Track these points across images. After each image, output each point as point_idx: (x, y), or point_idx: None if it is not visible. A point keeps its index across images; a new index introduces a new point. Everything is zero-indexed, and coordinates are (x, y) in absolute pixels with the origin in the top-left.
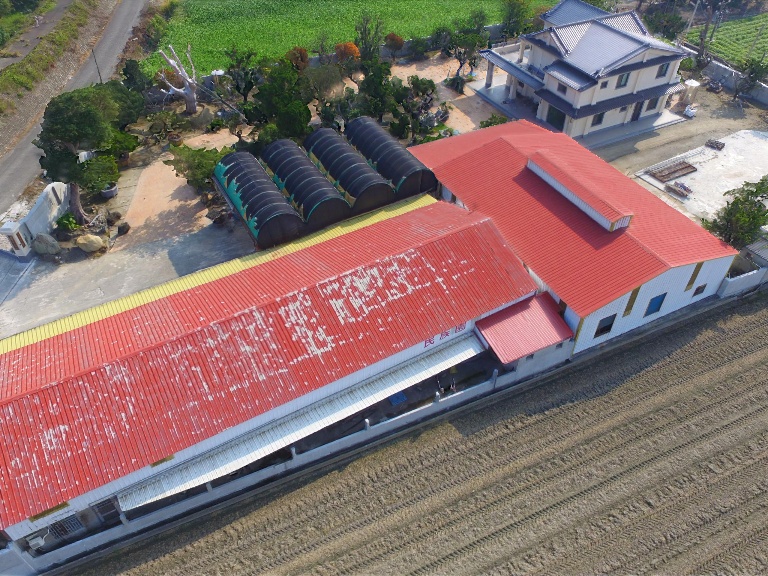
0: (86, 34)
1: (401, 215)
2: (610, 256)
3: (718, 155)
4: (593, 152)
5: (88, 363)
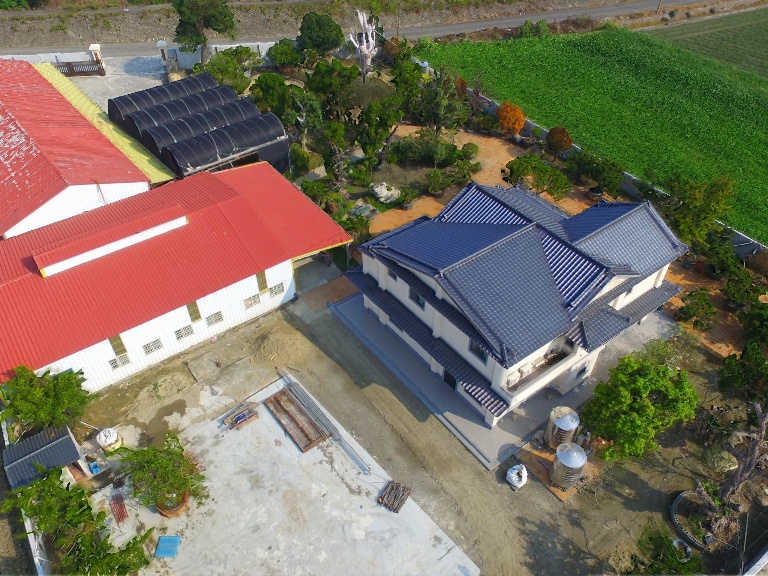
0: (495, 9)
1: (128, 161)
2: (6, 265)
3: (360, 495)
4: (347, 335)
5: None
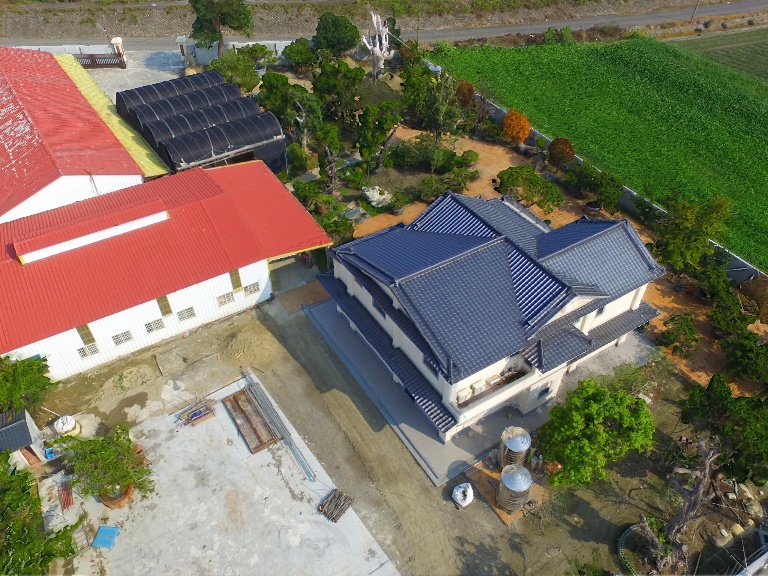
0: (520, 15)
1: (126, 153)
2: None
3: (302, 501)
4: (317, 338)
5: (6, 63)
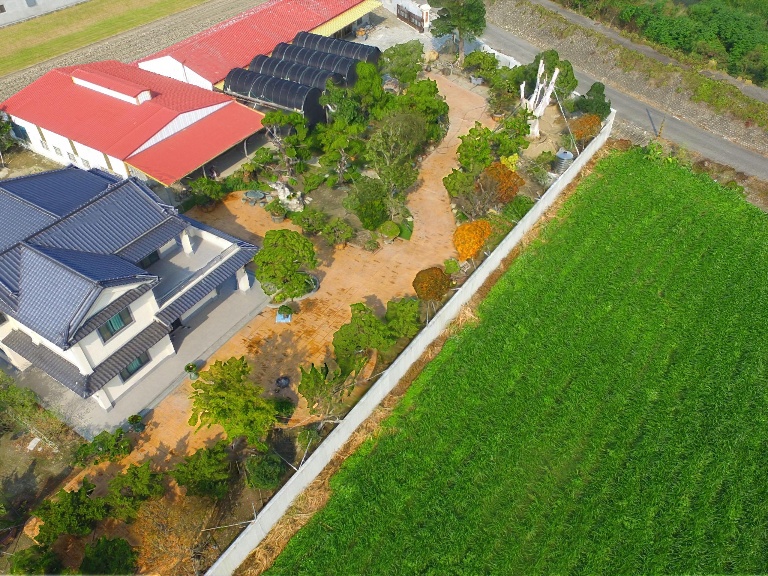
0: None
1: None
2: None
3: None
4: None
5: None
